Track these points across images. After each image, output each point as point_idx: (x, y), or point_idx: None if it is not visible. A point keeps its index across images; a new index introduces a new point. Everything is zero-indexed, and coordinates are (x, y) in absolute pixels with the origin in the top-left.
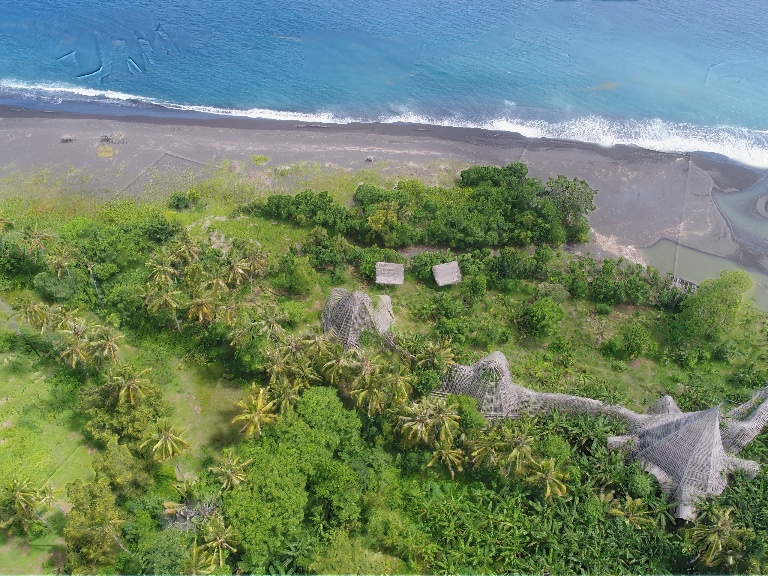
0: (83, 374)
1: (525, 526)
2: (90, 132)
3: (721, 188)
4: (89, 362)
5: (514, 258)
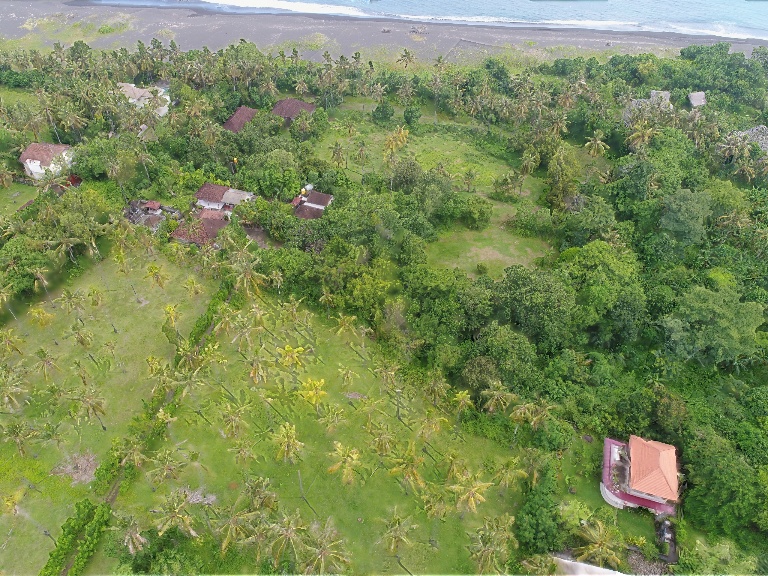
0: (491, 140)
1: None
2: (396, 28)
3: None
4: None
5: None
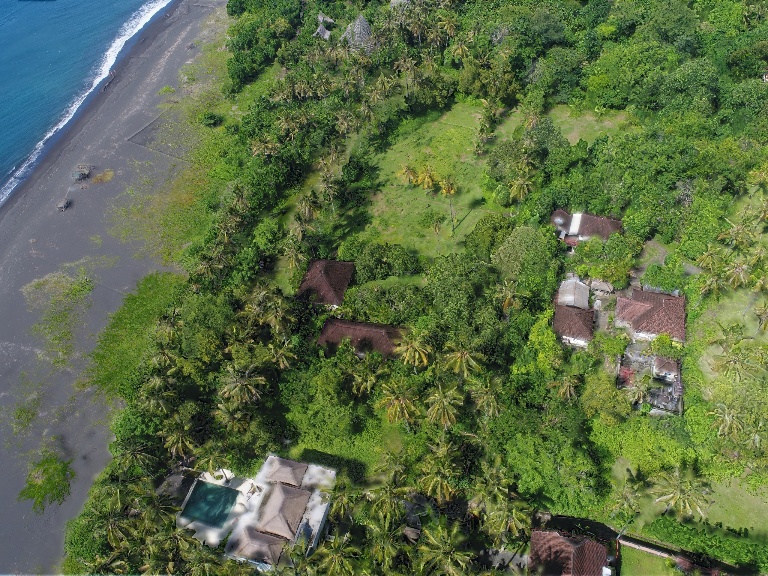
0: (392, 127)
1: (478, 3)
2: (49, 199)
3: None
4: (383, 126)
5: None
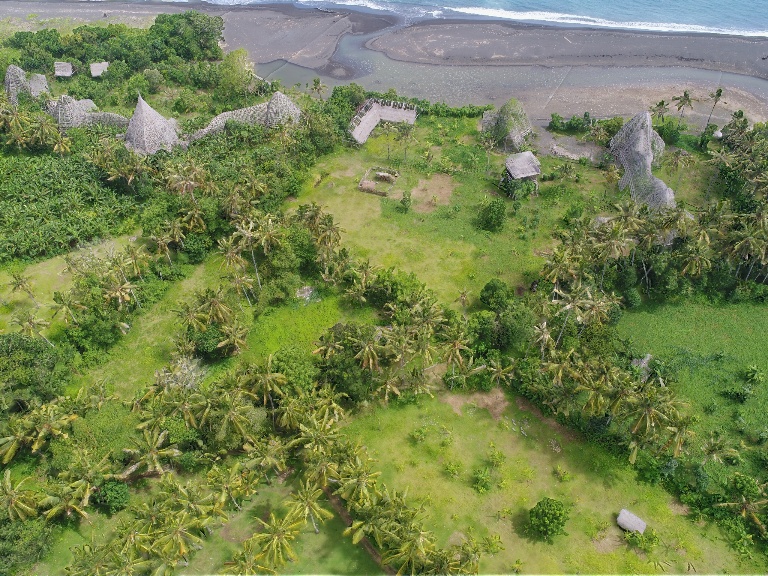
0: None
1: None
2: None
3: (353, 32)
4: None
5: (137, 57)
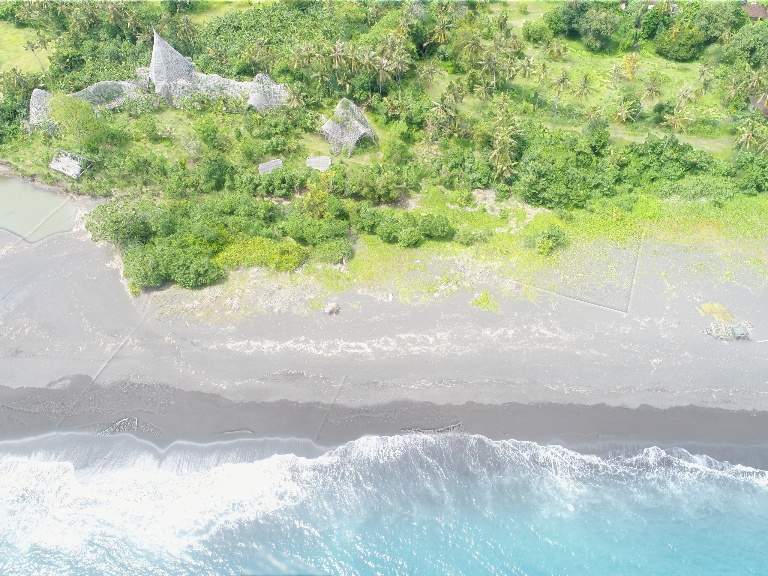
0: None
1: None
2: None
3: None
4: None
5: None
